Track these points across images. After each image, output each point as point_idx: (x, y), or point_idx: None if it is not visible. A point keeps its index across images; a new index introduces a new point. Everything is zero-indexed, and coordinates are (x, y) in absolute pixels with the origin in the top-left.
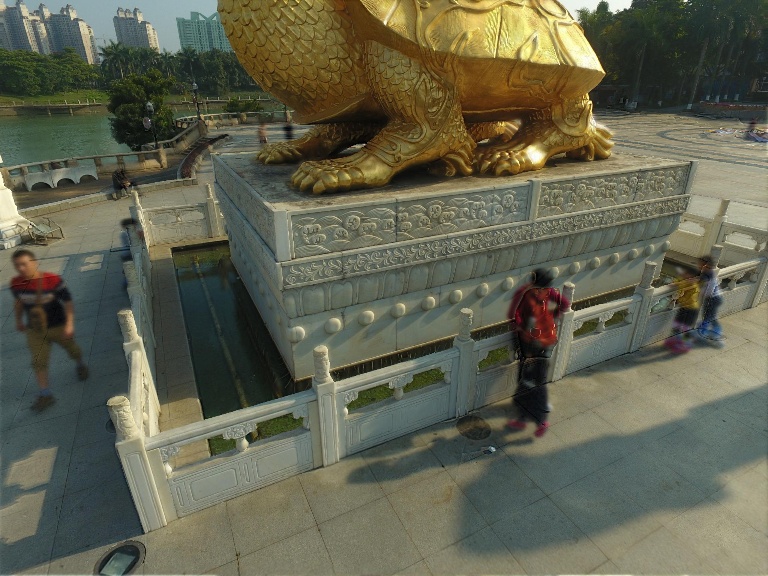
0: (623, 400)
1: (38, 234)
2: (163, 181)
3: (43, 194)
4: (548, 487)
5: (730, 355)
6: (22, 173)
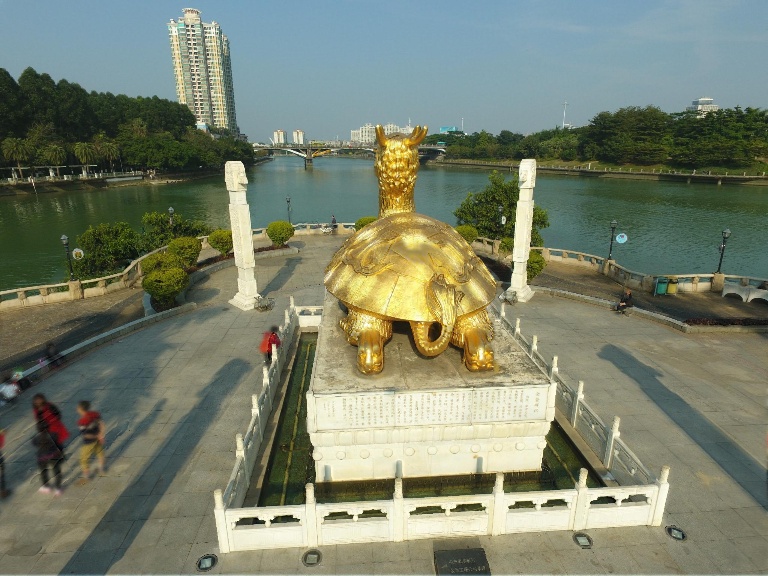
0: (251, 390)
1: (506, 298)
2: (664, 316)
3: (716, 301)
4: (246, 365)
5: (233, 434)
6: (741, 283)
